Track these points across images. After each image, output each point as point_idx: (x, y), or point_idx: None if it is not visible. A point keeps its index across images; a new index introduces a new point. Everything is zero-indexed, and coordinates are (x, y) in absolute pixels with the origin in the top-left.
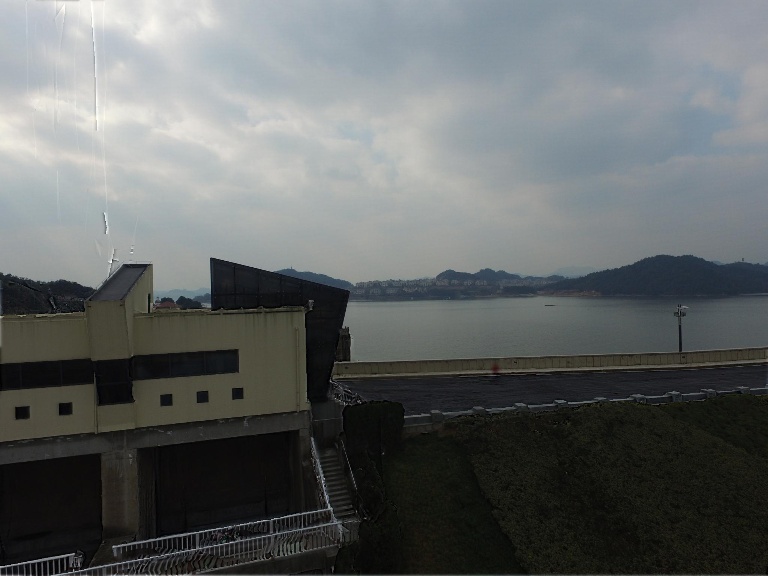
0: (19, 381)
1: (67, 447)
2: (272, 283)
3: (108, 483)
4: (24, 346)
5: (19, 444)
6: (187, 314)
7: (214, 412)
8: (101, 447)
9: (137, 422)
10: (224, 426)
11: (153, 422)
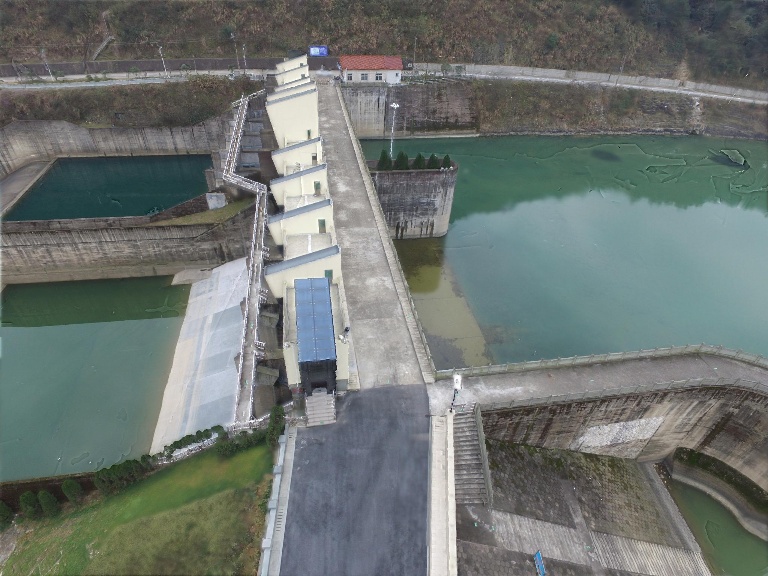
0: None
1: None
2: None
3: None
4: None
5: None
6: None
7: None
8: None
9: None
10: None
11: None
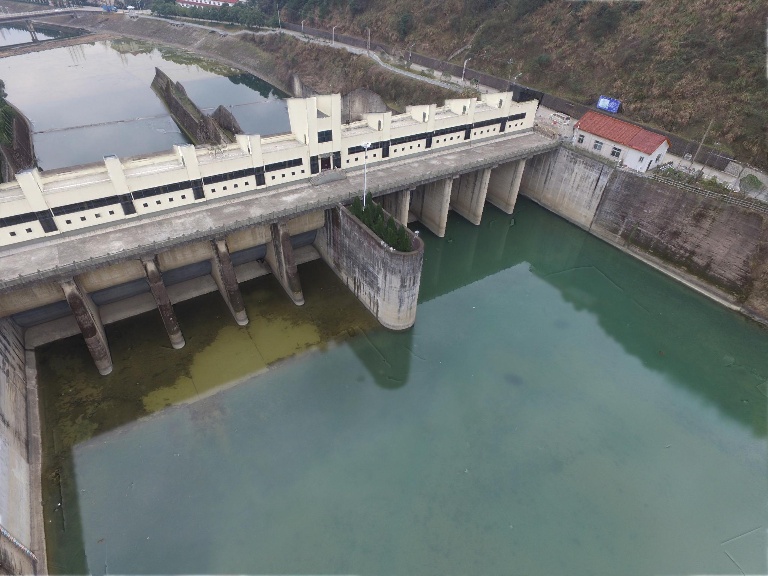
0: None
1: None
2: None
3: None
4: None
5: None
6: (2, 184)
7: None
8: None
9: None
10: None
11: None
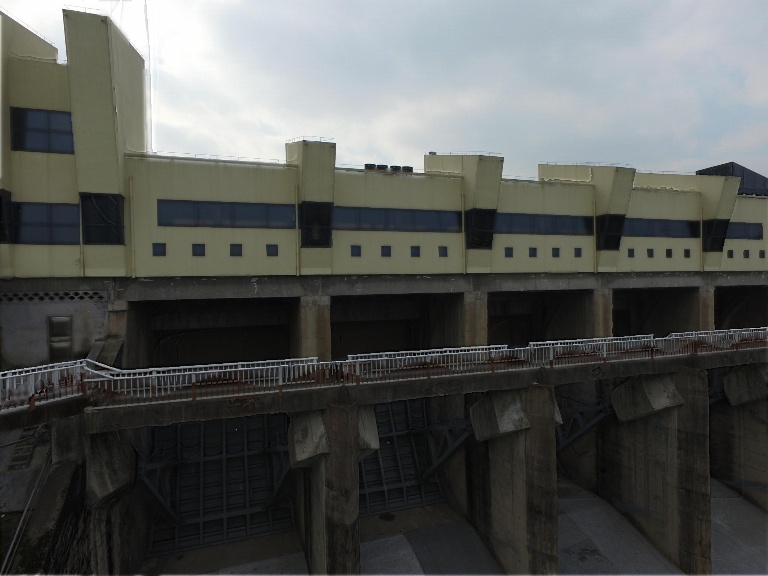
0: (667, 232)
1: (685, 280)
2: (760, 182)
3: (702, 307)
4: (669, 209)
5: (665, 275)
6: (739, 196)
7: (751, 266)
8: (699, 282)
9: (720, 266)
10: (753, 277)
11: (724, 268)
